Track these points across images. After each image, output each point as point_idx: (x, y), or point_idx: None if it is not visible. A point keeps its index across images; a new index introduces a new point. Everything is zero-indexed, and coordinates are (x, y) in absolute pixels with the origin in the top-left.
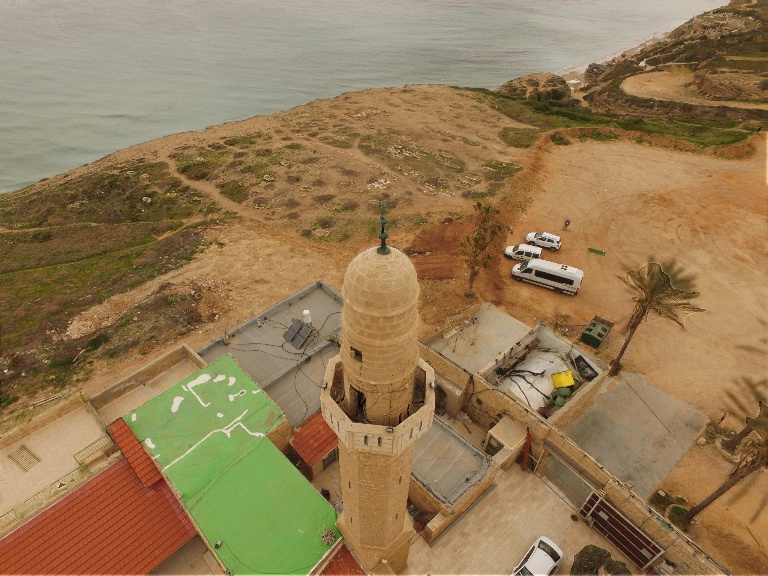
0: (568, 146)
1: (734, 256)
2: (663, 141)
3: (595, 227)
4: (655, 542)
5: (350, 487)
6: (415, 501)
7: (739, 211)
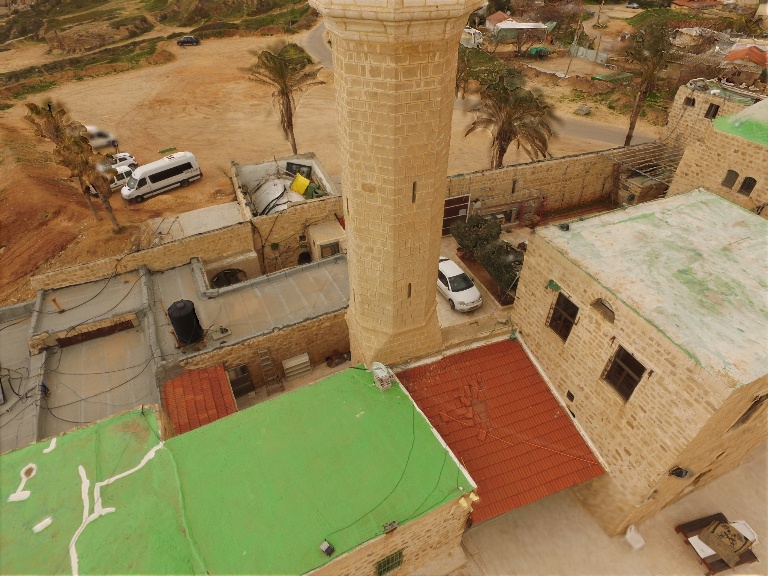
0: (13, 107)
1: (251, 106)
2: (100, 70)
3: (140, 139)
4: (463, 194)
5: (415, 198)
6: (345, 344)
7: (216, 85)
